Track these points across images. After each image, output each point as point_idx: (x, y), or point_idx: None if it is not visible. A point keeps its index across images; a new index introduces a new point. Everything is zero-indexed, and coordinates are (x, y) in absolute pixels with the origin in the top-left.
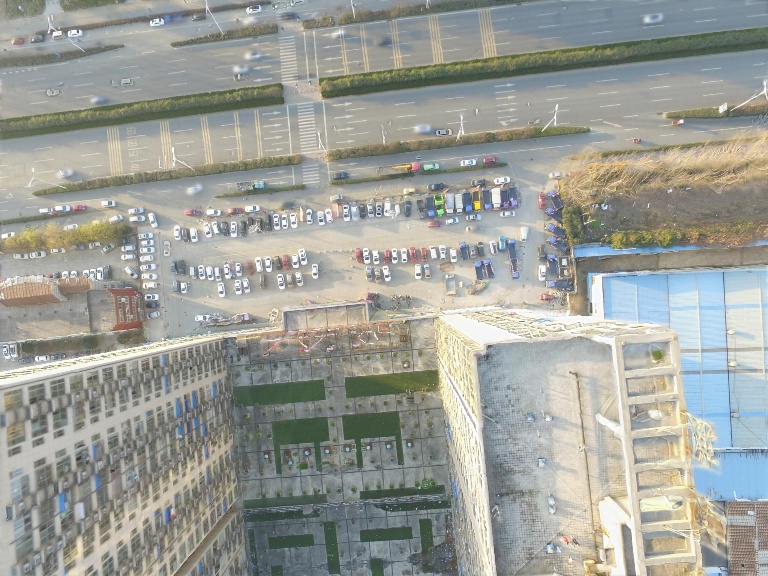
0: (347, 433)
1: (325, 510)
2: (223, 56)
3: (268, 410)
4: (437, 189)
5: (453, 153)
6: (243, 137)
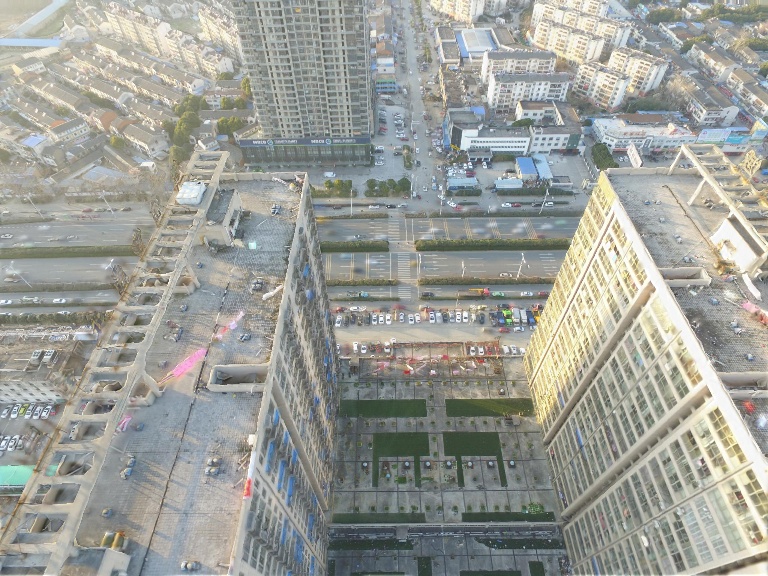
0: (448, 449)
1: (420, 541)
2: (349, 226)
3: (371, 422)
4: (504, 307)
5: (514, 288)
6: (356, 267)
